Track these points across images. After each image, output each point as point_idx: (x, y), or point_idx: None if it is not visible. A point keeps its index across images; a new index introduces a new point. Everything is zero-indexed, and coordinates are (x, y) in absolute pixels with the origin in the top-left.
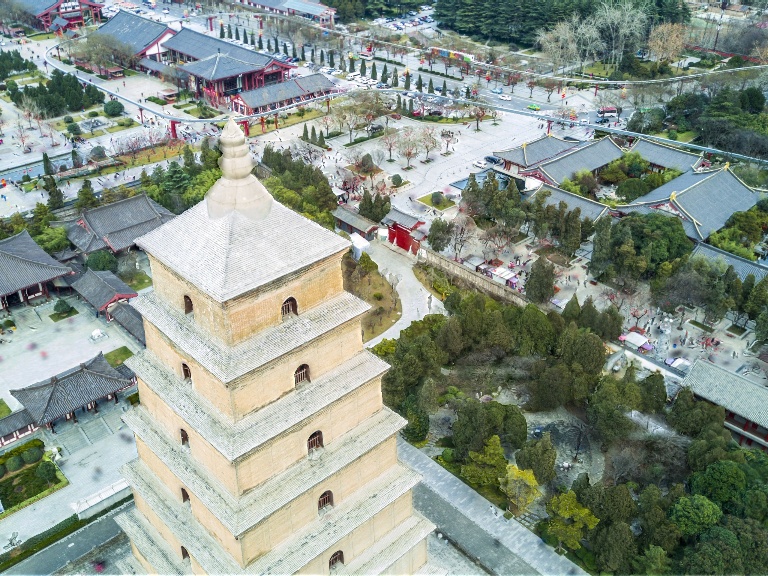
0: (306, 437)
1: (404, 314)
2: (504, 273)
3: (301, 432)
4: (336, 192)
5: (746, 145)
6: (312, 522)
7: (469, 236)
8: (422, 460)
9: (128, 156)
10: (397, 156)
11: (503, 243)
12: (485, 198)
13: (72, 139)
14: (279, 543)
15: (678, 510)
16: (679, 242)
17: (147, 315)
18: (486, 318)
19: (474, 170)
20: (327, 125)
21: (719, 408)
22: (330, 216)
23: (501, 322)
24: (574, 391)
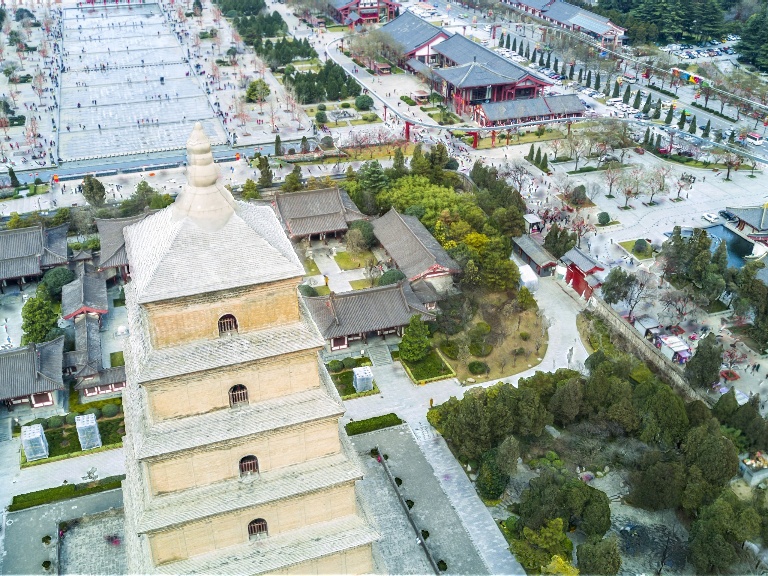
0: (237, 458)
1: (544, 361)
2: (675, 343)
3: (230, 451)
4: (531, 219)
5: None
6: (240, 544)
7: (649, 294)
8: (484, 519)
9: (356, 149)
10: (616, 193)
11: (687, 310)
12: (686, 256)
13: (314, 126)
14: (198, 554)
15: None
16: None
17: (127, 301)
18: (614, 388)
19: (701, 223)
20: (556, 149)
21: None
22: (507, 242)
23: (628, 396)
24: (684, 497)
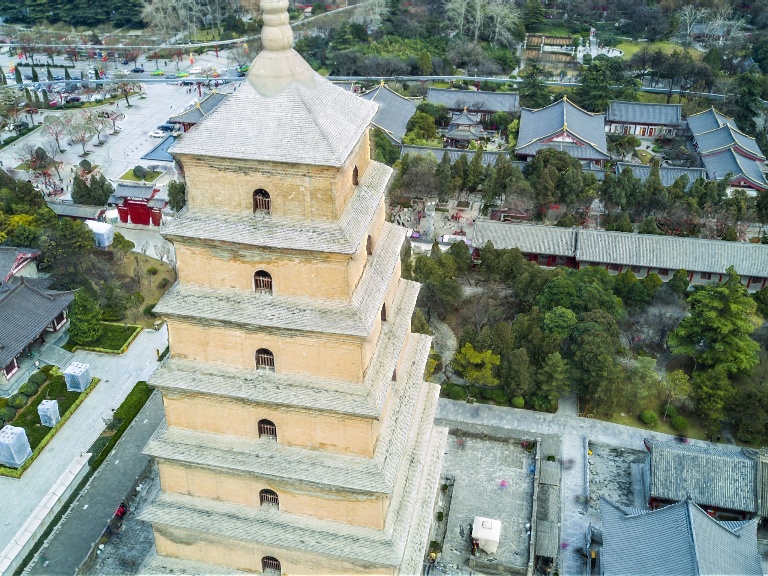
0: None
1: None
2: None
3: None
4: None
5: (381, 67)
6: (390, 400)
7: None
8: None
9: None
10: (68, 144)
11: None
12: None
13: None
14: (382, 426)
15: (549, 324)
16: (389, 148)
17: (197, 234)
18: None
19: (155, 141)
20: None
21: (517, 249)
22: None
23: None
24: None
